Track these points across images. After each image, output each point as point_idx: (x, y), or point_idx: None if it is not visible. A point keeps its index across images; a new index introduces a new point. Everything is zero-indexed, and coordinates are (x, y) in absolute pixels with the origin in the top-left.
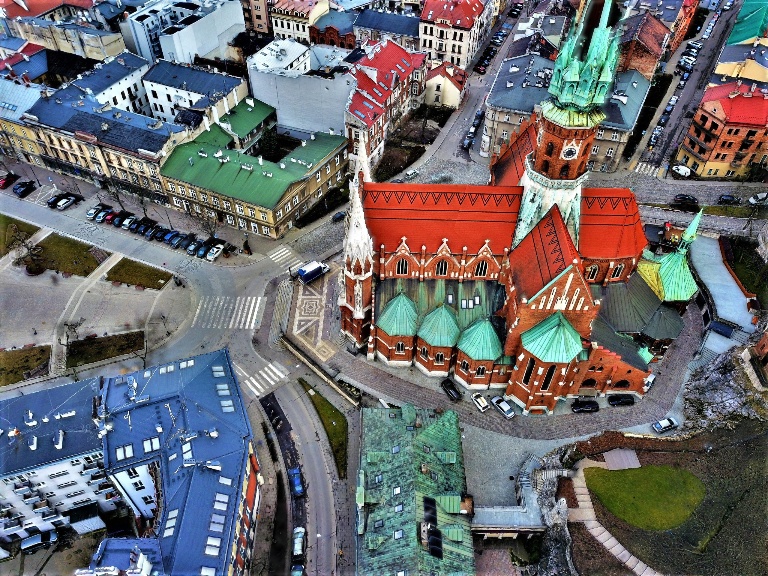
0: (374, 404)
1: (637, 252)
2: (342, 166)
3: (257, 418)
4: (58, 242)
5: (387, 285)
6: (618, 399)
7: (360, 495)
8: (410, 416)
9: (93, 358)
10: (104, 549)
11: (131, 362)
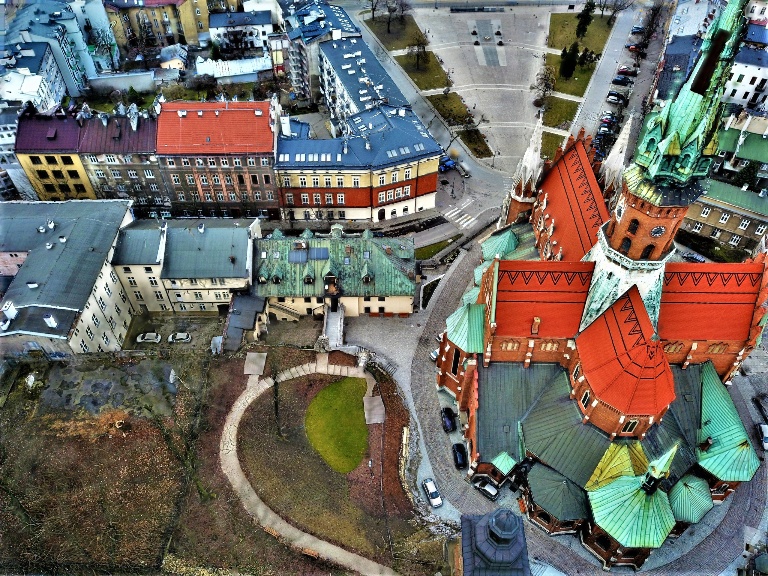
0: (440, 272)
1: (599, 394)
2: (748, 237)
3: (425, 216)
4: (570, 106)
5: (526, 228)
6: (459, 450)
7: (335, 225)
8: (398, 251)
9: (466, 140)
10: (302, 123)
11: (465, 155)
